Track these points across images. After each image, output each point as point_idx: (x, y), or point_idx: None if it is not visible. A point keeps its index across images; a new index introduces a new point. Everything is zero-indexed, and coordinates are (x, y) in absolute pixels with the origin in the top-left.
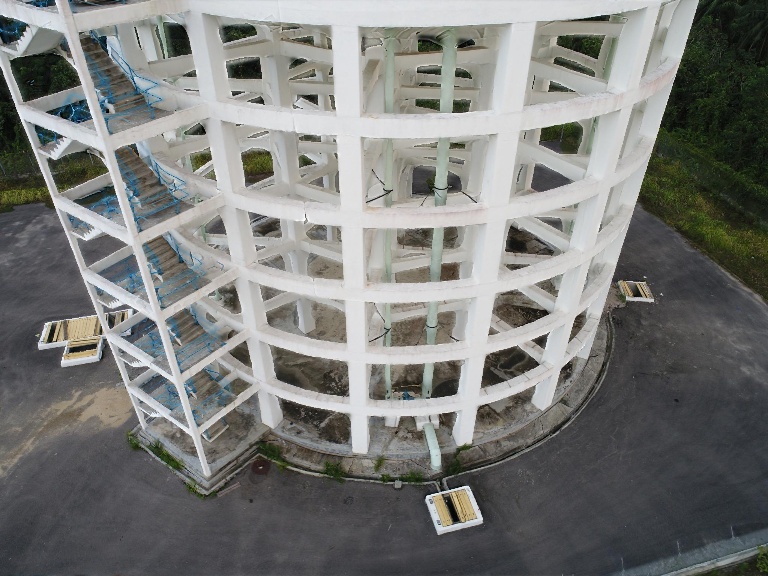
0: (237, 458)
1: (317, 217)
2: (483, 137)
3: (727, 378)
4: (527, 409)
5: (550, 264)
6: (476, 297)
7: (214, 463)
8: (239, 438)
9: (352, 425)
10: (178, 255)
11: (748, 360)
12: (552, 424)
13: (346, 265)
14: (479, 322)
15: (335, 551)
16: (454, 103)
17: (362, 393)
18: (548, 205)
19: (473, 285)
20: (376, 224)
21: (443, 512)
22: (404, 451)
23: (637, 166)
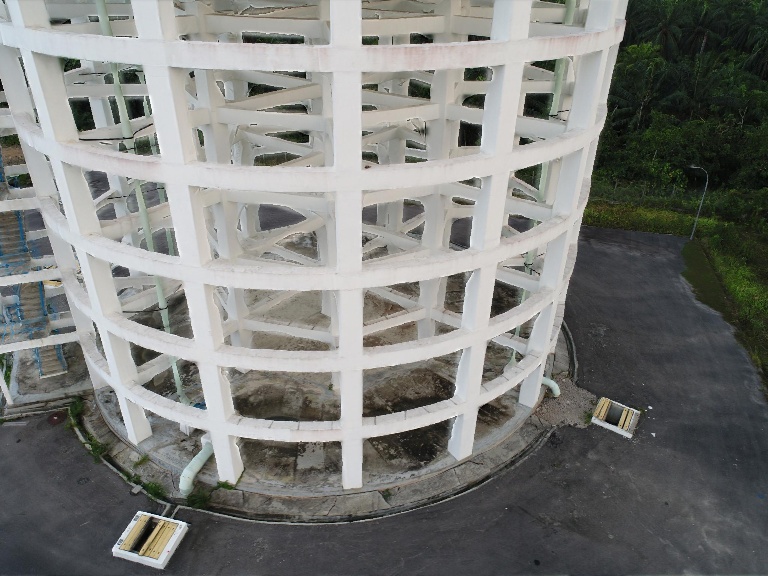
0: (48, 402)
1: (35, 143)
2: (324, 129)
3: (647, 572)
4: (330, 479)
5: (280, 271)
6: (182, 281)
7: (23, 395)
8: (63, 385)
9: (120, 404)
10: (2, 174)
11: (708, 566)
12: (347, 510)
13: (64, 203)
14: (195, 317)
15: (22, 518)
16: (598, 179)
17: (114, 367)
18: (243, 181)
19: (174, 263)
20: (68, 158)
21: (134, 534)
22: (167, 459)
23: (431, 179)
